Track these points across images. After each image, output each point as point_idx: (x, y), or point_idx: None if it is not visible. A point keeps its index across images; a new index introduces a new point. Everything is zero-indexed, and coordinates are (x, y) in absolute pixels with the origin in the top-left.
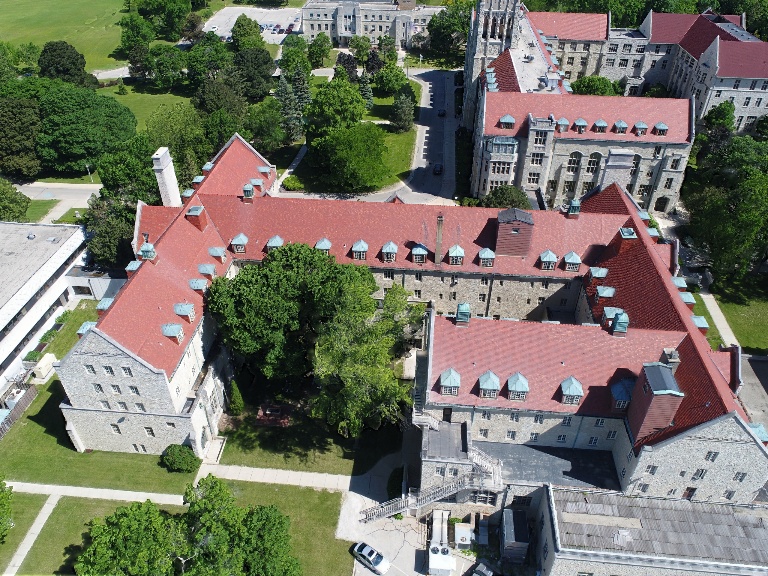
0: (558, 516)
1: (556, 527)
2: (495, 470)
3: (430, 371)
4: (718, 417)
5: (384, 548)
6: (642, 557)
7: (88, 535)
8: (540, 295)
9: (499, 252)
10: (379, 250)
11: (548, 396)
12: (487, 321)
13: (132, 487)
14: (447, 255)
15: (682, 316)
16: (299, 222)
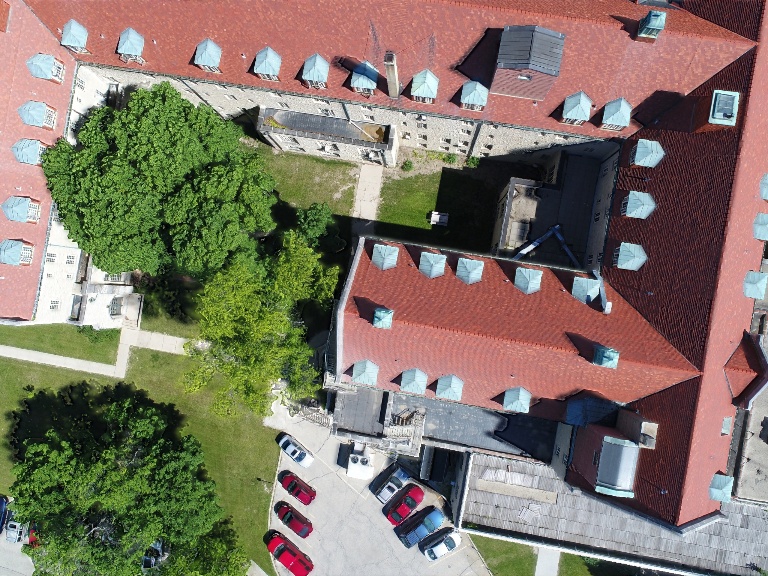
0: (472, 483)
1: (462, 507)
2: (416, 431)
3: (339, 365)
4: (661, 526)
5: (310, 439)
6: (538, 546)
7: (30, 401)
8: (554, 142)
9: (496, 90)
10: (299, 67)
11: (487, 397)
12: (417, 327)
13: (57, 351)
14: (410, 86)
15: (712, 334)
16: (159, 7)
